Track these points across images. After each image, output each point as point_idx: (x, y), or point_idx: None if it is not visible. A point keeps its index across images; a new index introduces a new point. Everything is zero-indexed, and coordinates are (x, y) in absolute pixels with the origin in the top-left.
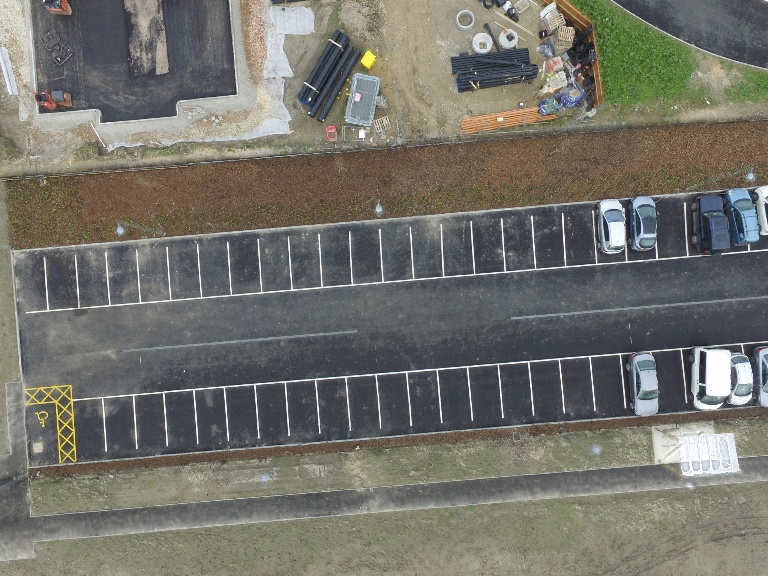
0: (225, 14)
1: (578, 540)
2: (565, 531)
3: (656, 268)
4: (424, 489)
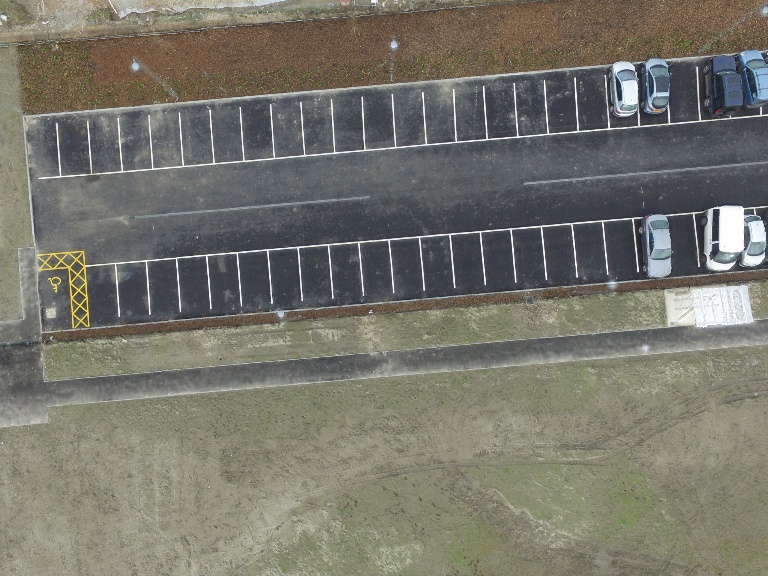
0: None
1: (591, 403)
2: (578, 394)
3: (668, 133)
4: (437, 353)
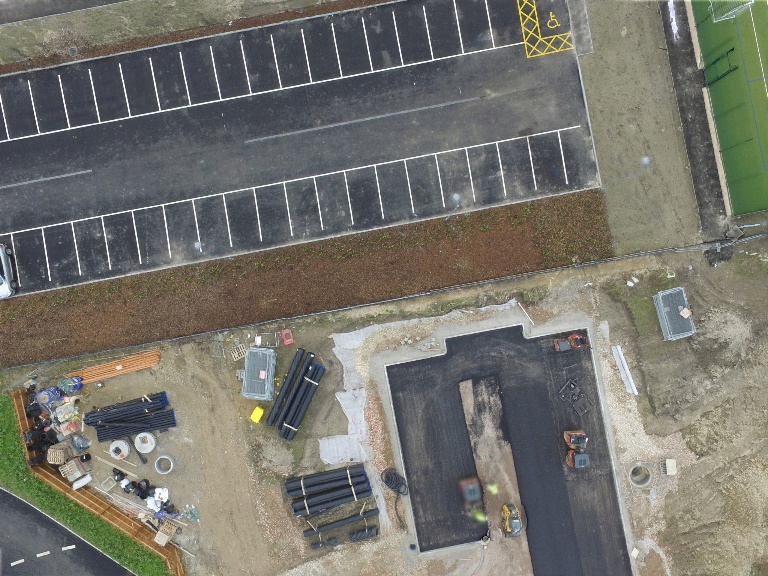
0: (407, 447)
1: None
2: None
3: None
4: None
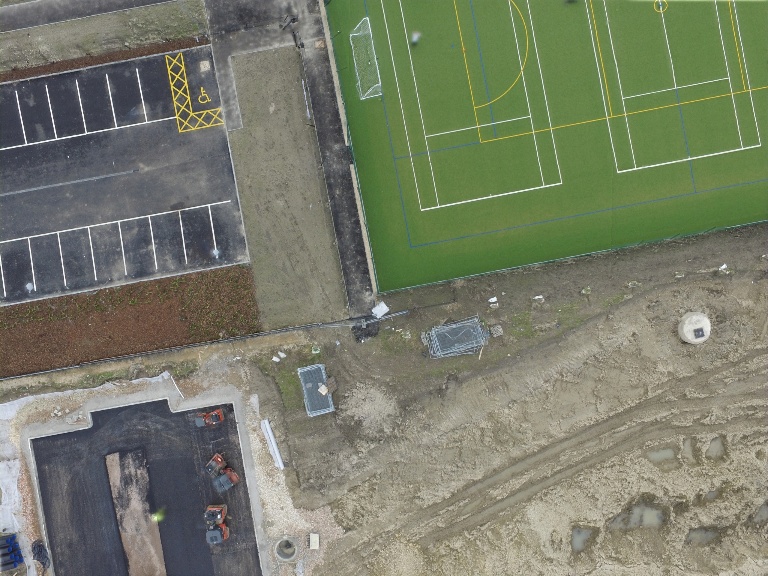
0: (51, 520)
1: None
2: None
3: None
4: None
